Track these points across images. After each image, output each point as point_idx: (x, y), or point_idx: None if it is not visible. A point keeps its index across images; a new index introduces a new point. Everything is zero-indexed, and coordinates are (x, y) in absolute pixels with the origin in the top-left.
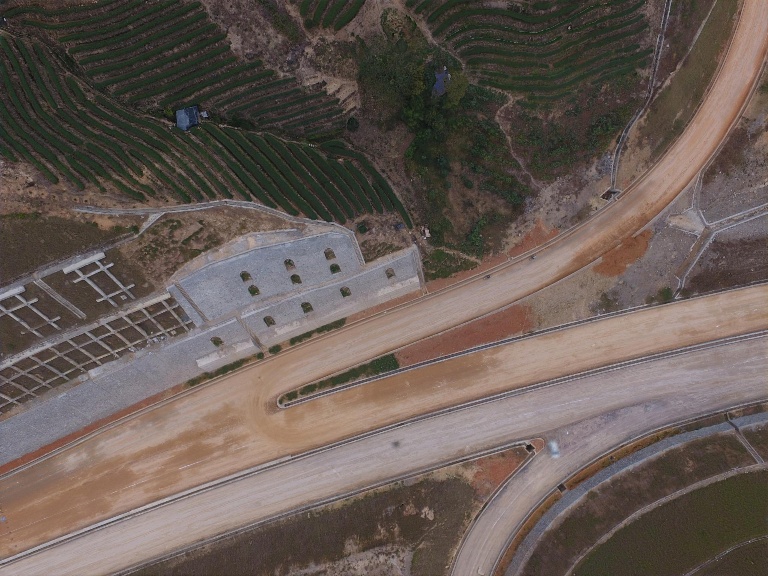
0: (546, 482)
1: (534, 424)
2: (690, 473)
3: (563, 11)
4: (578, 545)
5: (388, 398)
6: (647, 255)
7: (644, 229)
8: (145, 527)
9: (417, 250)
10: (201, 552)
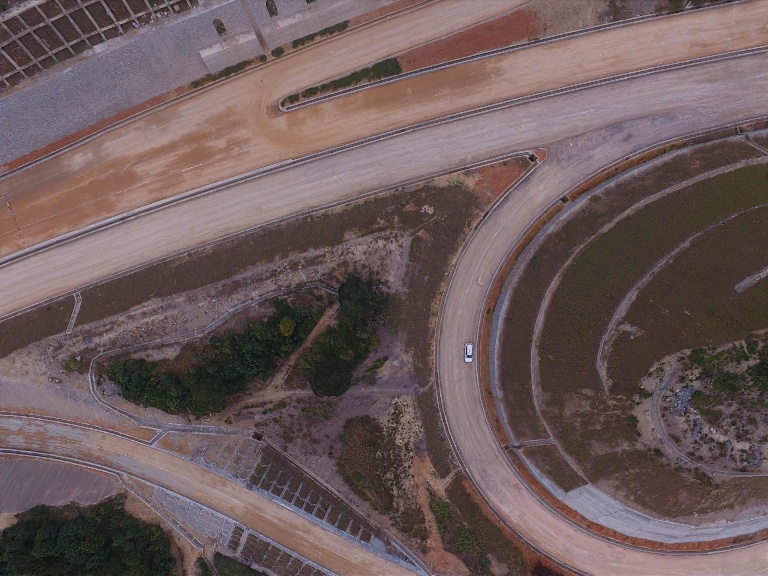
0: (548, 194)
1: (537, 135)
2: (697, 168)
3: None
4: (579, 237)
5: (390, 105)
6: None
7: None
8: (148, 229)
9: None
10: (203, 253)
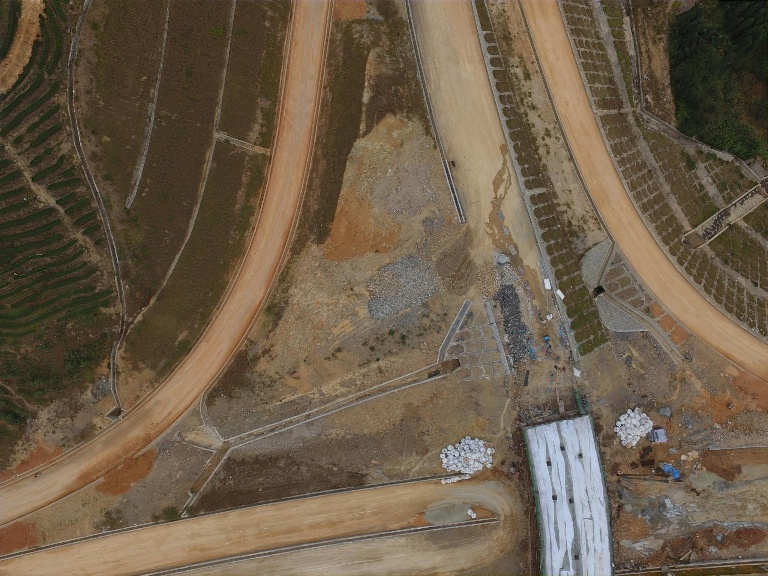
0: None
1: None
2: None
3: None
4: None
5: None
6: (151, 474)
7: (147, 449)
8: None
9: None
10: None
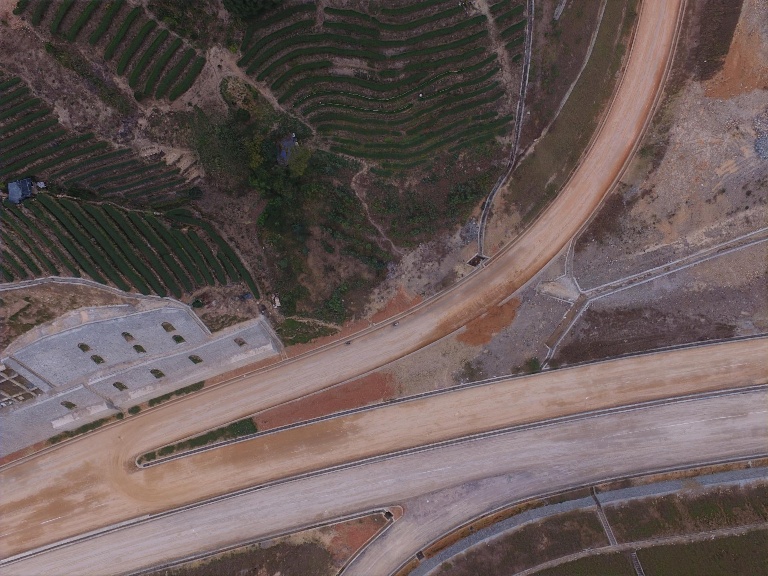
0: (405, 549)
1: (394, 491)
2: (542, 551)
3: (411, 79)
4: None
5: (247, 461)
6: (514, 324)
7: (511, 297)
8: None
9: (264, 321)
10: None
